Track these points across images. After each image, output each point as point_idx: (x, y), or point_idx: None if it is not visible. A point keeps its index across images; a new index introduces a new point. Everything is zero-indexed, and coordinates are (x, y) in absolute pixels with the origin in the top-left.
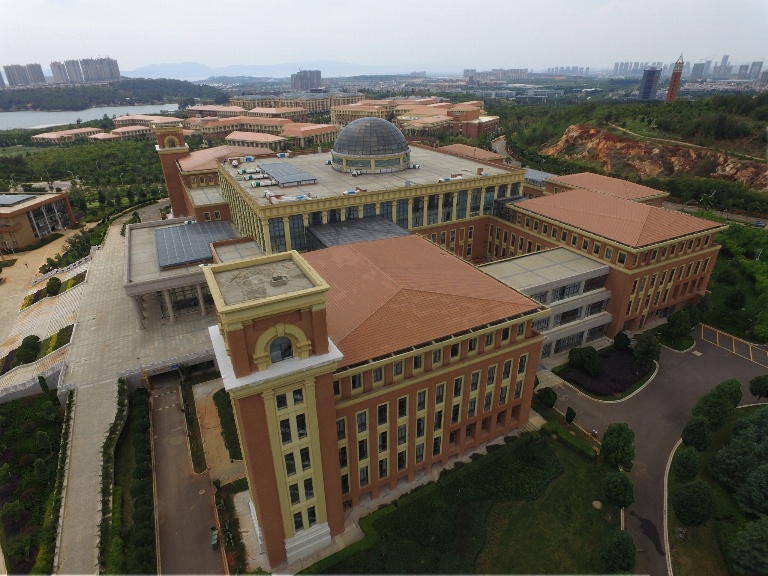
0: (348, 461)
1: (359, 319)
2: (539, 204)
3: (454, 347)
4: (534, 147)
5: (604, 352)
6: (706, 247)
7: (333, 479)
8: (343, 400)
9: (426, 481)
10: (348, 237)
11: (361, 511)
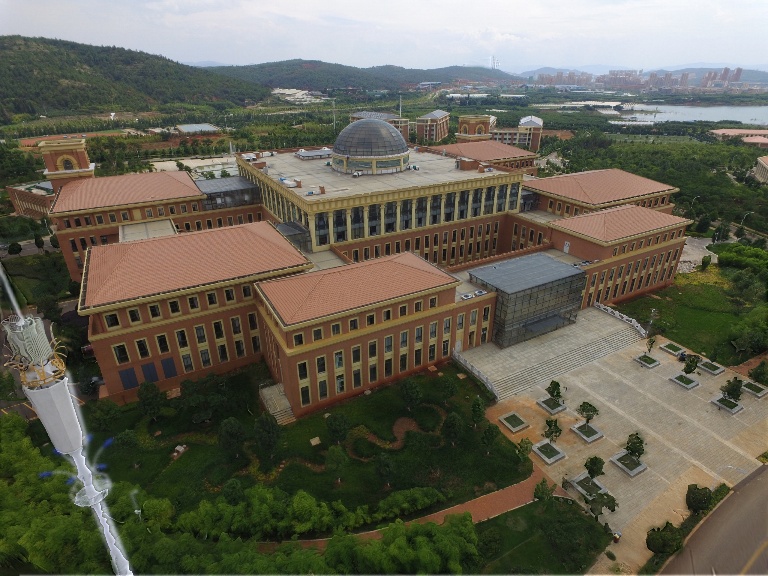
0: None
1: None
2: None
3: None
4: None
5: None
6: None
7: None
8: None
9: None
10: None
11: None
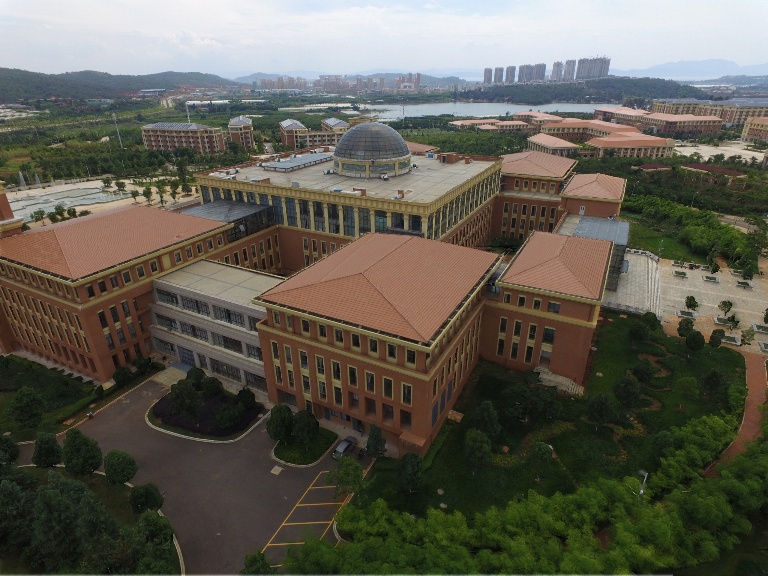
0: None
1: None
2: (367, 239)
3: None
4: None
5: (233, 398)
6: (412, 367)
7: None
8: None
9: (46, 365)
10: None
11: (22, 354)
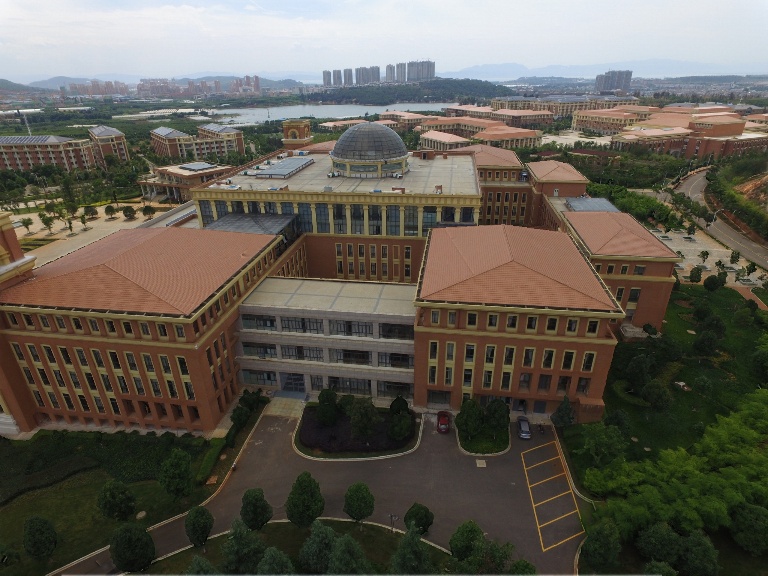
0: (34, 380)
1: (53, 276)
2: (446, 234)
3: (111, 323)
4: (739, 178)
5: None
6: (592, 336)
7: (4, 384)
8: (12, 329)
9: (104, 431)
10: (231, 226)
11: (53, 426)
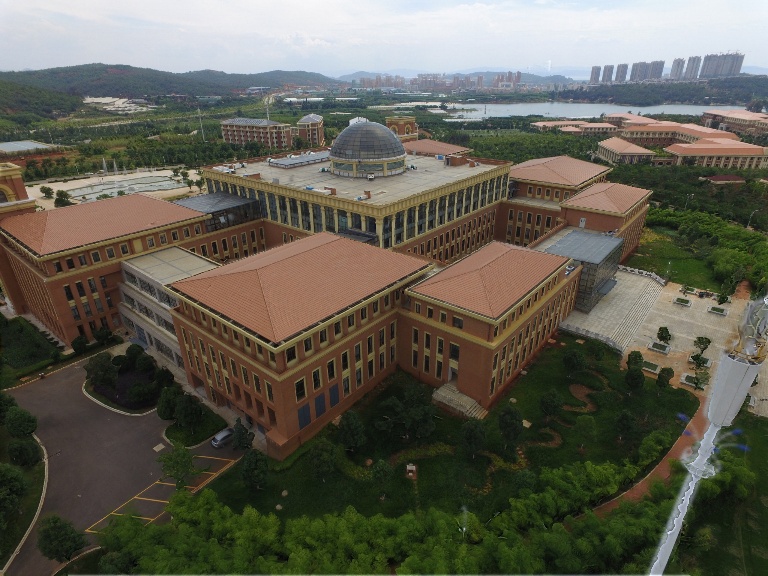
0: None
1: None
2: None
3: None
4: None
5: None
6: (274, 366)
7: None
8: None
9: (40, 328)
10: (198, 201)
11: None
